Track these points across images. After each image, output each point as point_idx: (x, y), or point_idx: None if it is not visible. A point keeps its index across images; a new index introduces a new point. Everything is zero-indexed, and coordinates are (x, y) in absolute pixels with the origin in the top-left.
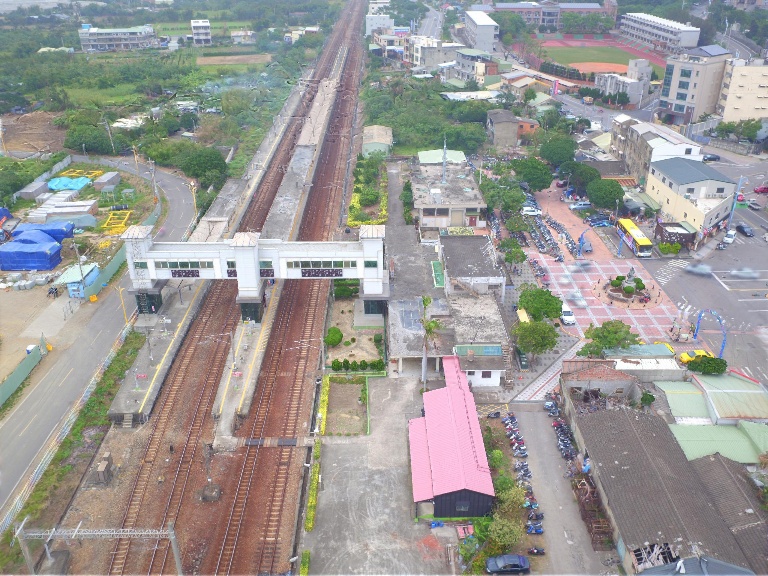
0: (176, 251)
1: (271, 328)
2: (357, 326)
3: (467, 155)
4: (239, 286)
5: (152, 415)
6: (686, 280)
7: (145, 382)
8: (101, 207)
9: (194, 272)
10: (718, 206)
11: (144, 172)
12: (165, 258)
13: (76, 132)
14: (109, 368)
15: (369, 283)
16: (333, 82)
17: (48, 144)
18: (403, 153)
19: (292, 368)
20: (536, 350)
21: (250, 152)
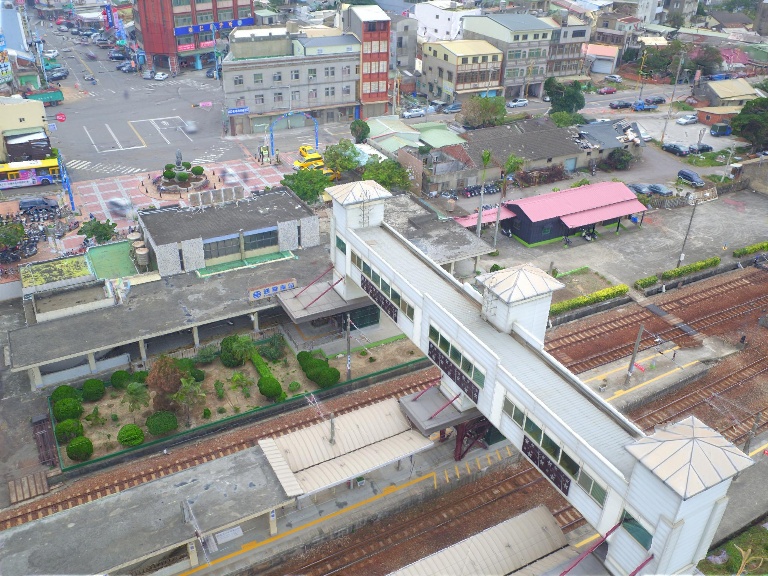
0: None
1: None
2: None
3: None
4: None
5: None
6: (130, 160)
7: (765, 461)
8: None
9: None
10: (2, 98)
11: None
12: None
13: None
14: None
15: None
16: None
17: None
18: None
19: None
20: None
21: None
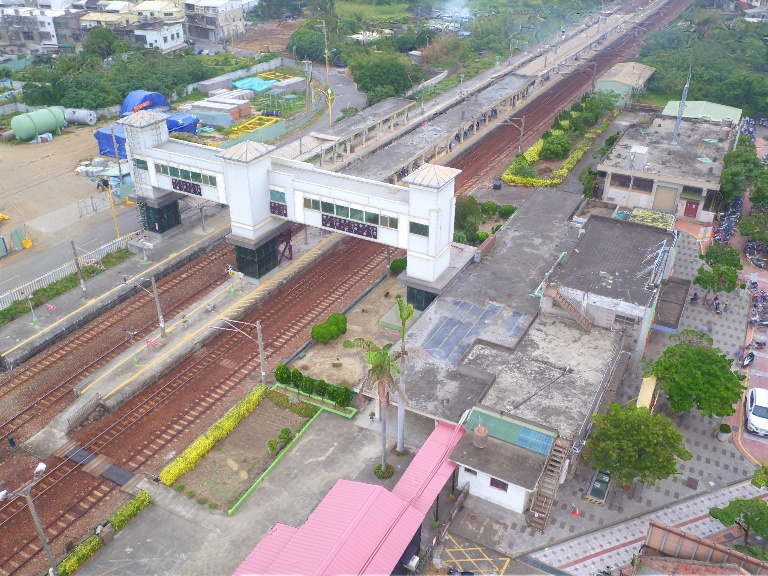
0: (176, 153)
1: (271, 290)
2: (384, 322)
3: (753, 118)
4: (232, 218)
5: (21, 364)
6: None
7: (54, 317)
8: (259, 111)
9: (196, 187)
10: None
11: (337, 84)
12: (165, 160)
13: (298, 35)
14: (49, 286)
15: (415, 259)
16: (627, 16)
17: (283, 48)
18: (656, 103)
19: (244, 357)
20: (620, 472)
21: (465, 78)
